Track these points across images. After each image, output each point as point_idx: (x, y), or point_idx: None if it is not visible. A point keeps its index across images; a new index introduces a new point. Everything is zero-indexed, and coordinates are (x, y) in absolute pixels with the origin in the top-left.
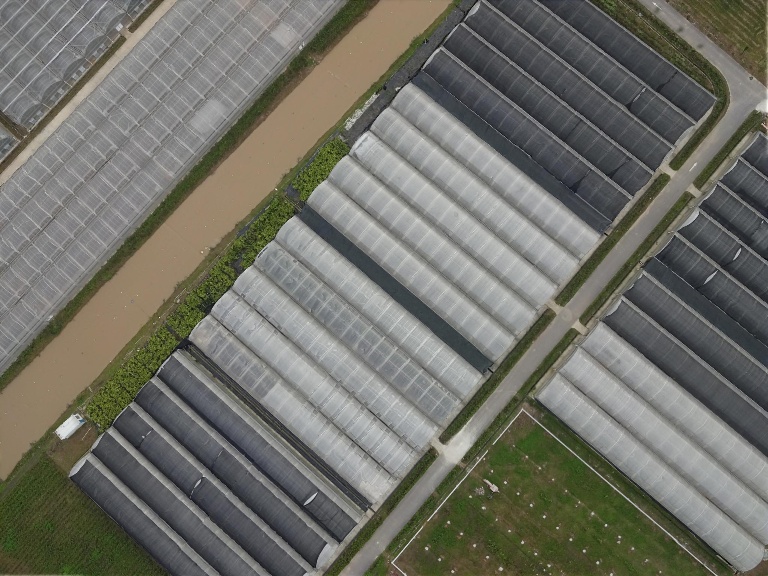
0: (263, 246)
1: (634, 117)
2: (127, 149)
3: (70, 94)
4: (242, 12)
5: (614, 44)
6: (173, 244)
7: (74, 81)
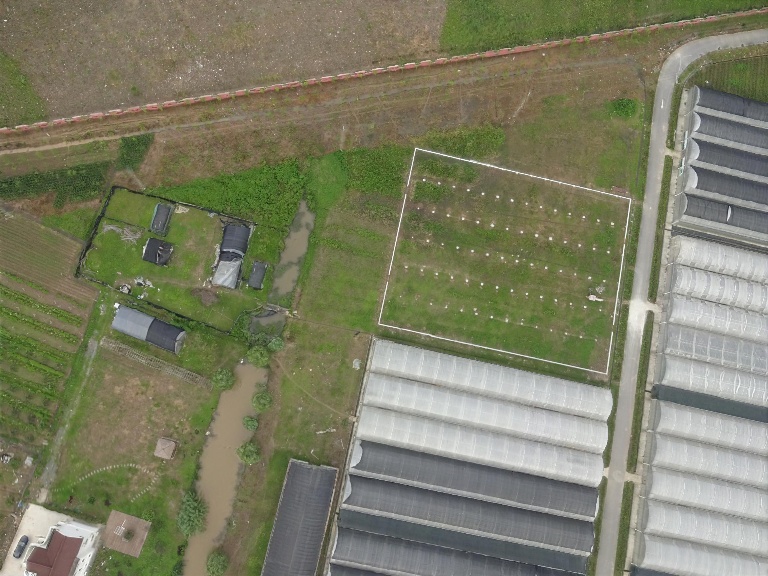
0: None
1: None
2: None
3: None
4: None
5: None
6: None
7: None
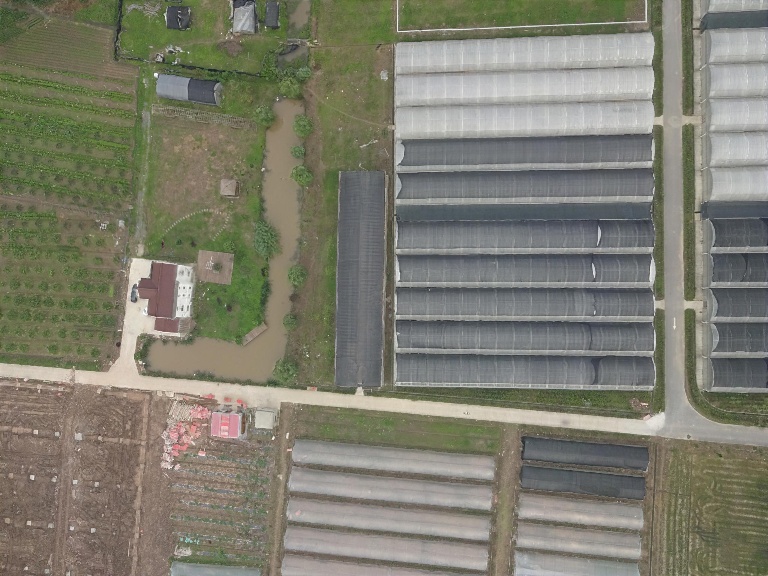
0: None
1: None
2: None
3: None
4: None
5: None
6: None
7: None
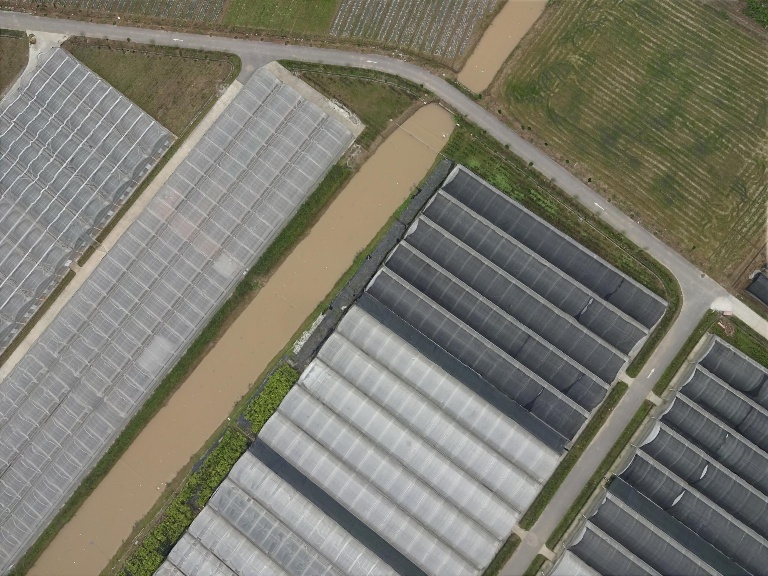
0: (217, 482)
1: (583, 329)
2: (78, 392)
3: (24, 332)
4: (185, 244)
5: (557, 252)
6: (129, 481)
7: (27, 318)
